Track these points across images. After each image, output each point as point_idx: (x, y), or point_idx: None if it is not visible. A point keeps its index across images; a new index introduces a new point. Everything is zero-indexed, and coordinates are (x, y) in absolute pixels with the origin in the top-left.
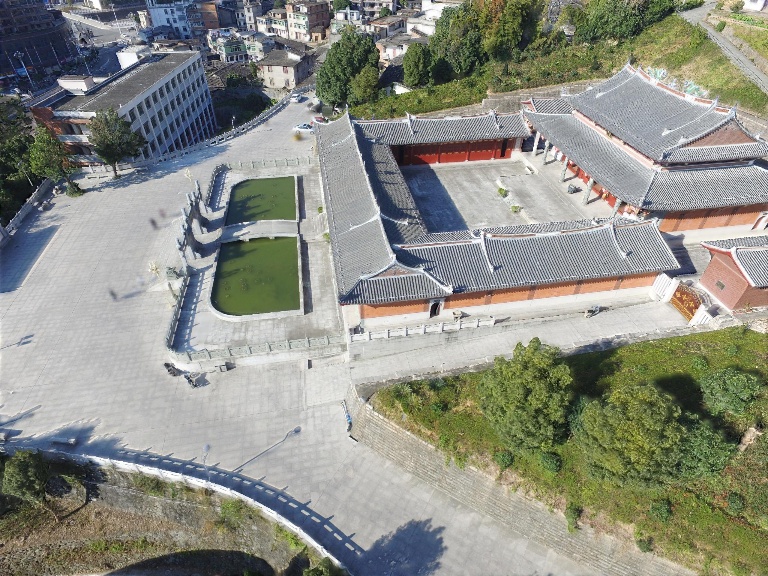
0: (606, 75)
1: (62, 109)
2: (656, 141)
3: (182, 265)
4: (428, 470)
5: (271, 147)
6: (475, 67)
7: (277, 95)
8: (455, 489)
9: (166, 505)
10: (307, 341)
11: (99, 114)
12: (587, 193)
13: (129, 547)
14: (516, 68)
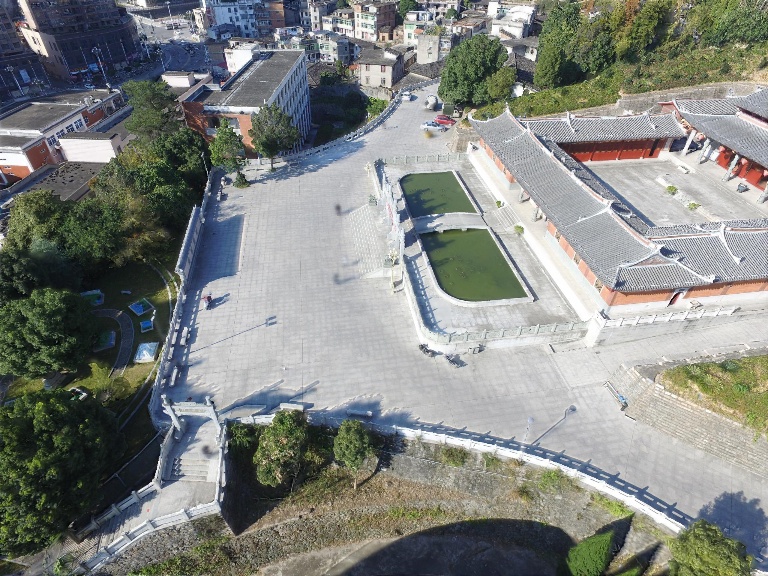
0: (736, 78)
1: (208, 104)
2: None
3: None
4: (726, 447)
5: (406, 143)
6: (602, 68)
7: (375, 93)
8: (758, 465)
9: (460, 475)
10: (555, 326)
11: (264, 109)
12: (766, 192)
13: (425, 514)
14: (645, 70)
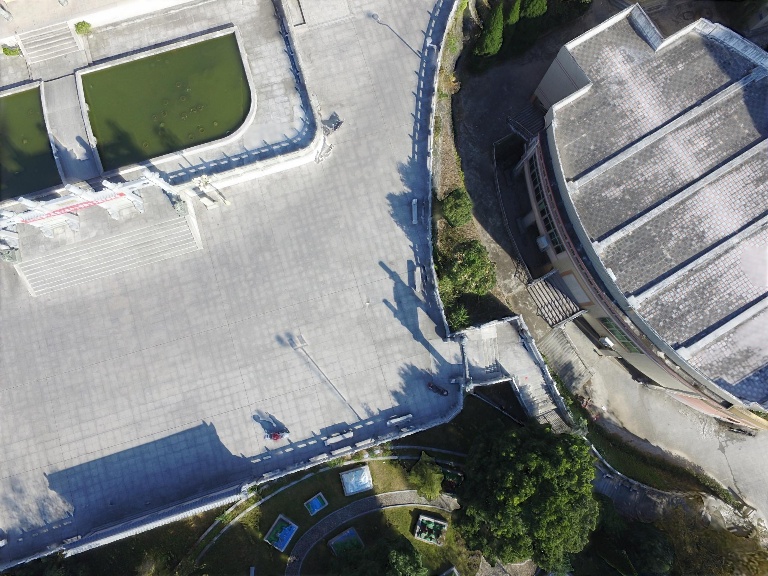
0: None
1: None
2: None
3: (155, 210)
4: None
5: None
6: None
7: None
8: None
9: None
10: None
11: None
12: None
13: None
14: None
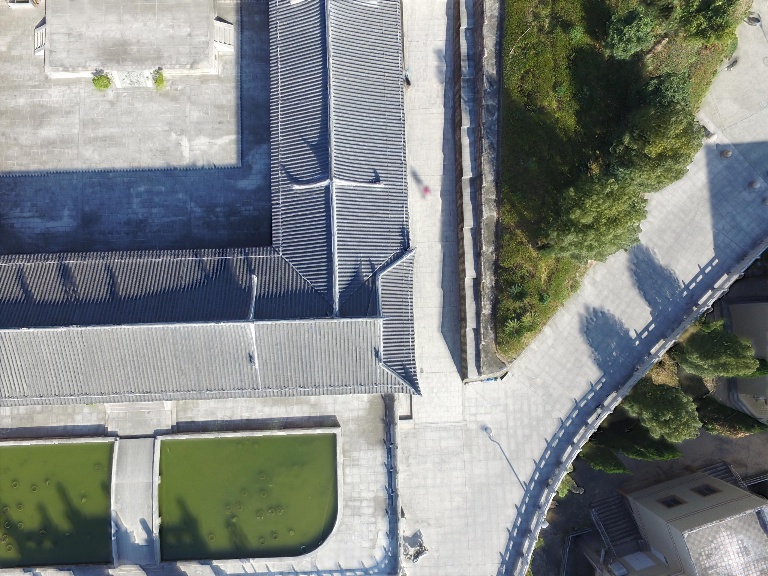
0: None
1: None
2: None
3: None
4: None
5: None
6: None
7: None
8: None
9: None
10: None
11: None
12: None
13: None
14: None
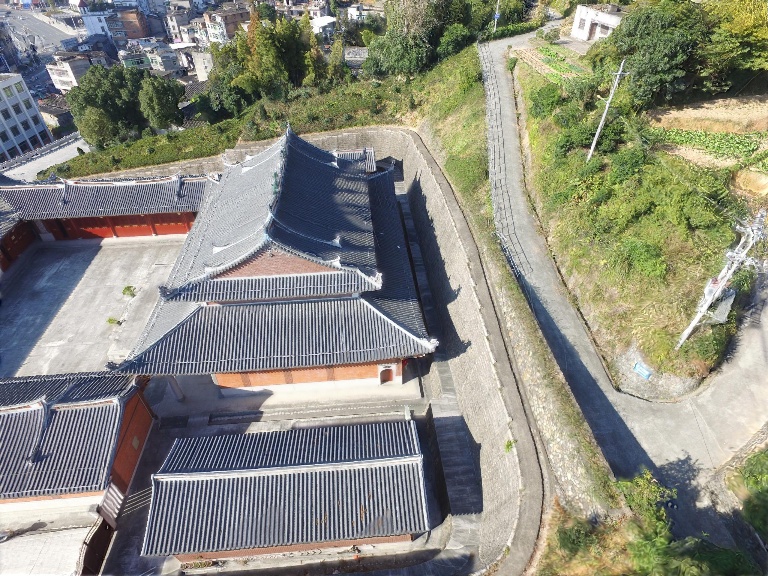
0: (386, 121)
1: None
2: (201, 262)
3: None
4: None
5: None
6: (242, 106)
7: None
8: None
9: None
10: None
11: None
12: None
13: None
14: (285, 109)
